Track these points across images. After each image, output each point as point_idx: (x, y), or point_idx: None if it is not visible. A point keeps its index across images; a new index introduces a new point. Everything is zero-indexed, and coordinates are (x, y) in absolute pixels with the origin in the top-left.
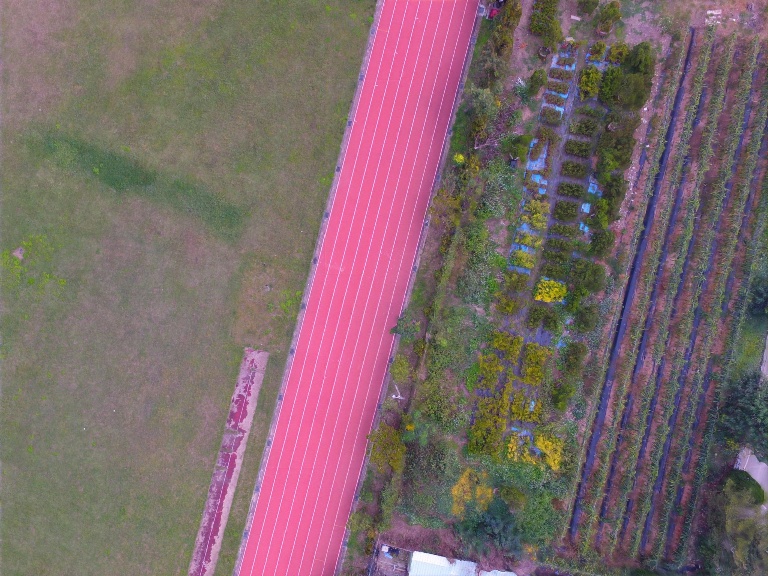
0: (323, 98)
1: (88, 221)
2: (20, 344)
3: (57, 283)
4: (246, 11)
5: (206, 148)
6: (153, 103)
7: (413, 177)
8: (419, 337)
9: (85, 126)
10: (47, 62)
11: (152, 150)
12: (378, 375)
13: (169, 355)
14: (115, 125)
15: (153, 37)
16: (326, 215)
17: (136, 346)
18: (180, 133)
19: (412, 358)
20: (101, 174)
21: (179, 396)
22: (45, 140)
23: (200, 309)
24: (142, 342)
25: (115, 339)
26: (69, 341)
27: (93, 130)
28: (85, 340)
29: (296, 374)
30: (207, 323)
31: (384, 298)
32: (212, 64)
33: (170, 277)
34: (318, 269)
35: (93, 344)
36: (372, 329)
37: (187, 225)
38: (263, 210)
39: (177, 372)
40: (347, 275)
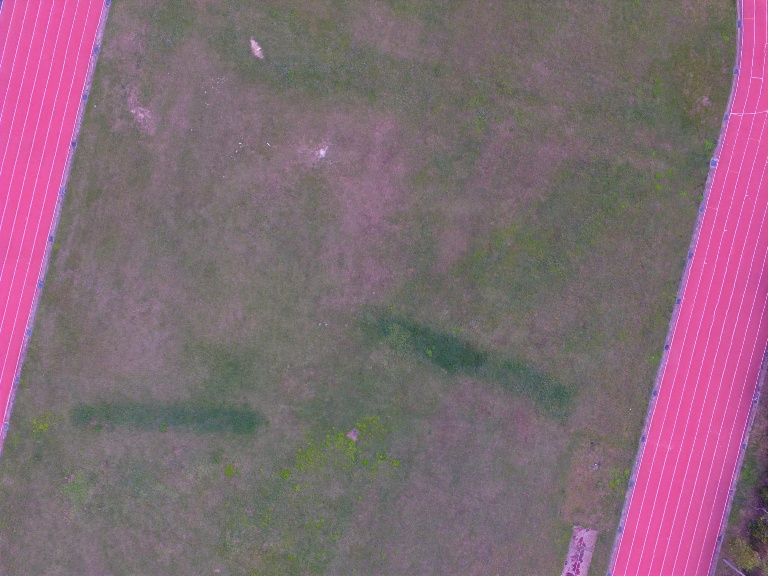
0: (652, 277)
1: (420, 402)
2: (354, 525)
3: (390, 464)
4: (576, 191)
5: (536, 328)
6: (484, 284)
7: (742, 355)
8: (750, 516)
9: (417, 308)
10: (381, 246)
11: (483, 331)
12: (707, 553)
13: (499, 534)
14: (447, 307)
15: (484, 219)
16: (654, 393)
17: (466, 525)
18: (510, 314)
19: (742, 536)
20: (433, 356)
21: (509, 575)
22: (379, 323)
23: (529, 488)
24: (472, 521)
25: (446, 519)
26: (402, 521)
27: (425, 312)
28: (417, 520)
29: (625, 552)
30: (536, 502)
31: (713, 476)
32: (543, 245)
33: (500, 456)
34: (646, 447)
35: (425, 524)
36: (701, 507)
37: (517, 405)
38: (592, 389)
39: (507, 551)
40: (676, 453)
